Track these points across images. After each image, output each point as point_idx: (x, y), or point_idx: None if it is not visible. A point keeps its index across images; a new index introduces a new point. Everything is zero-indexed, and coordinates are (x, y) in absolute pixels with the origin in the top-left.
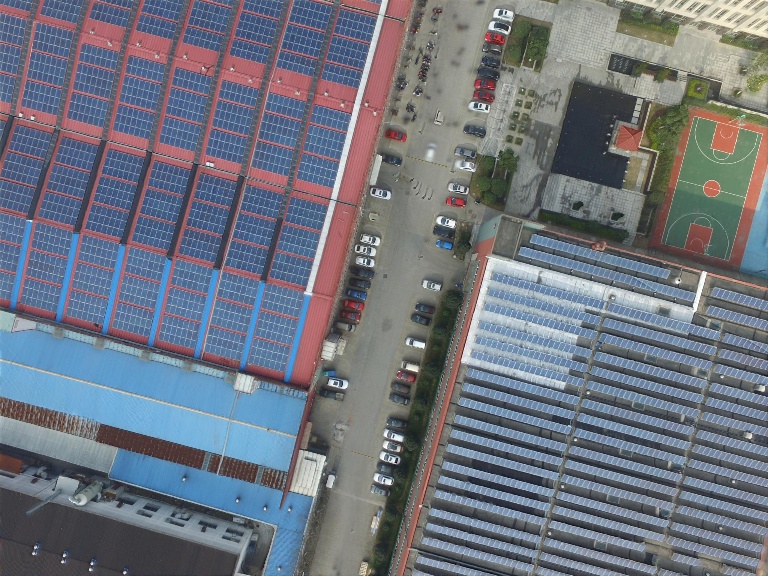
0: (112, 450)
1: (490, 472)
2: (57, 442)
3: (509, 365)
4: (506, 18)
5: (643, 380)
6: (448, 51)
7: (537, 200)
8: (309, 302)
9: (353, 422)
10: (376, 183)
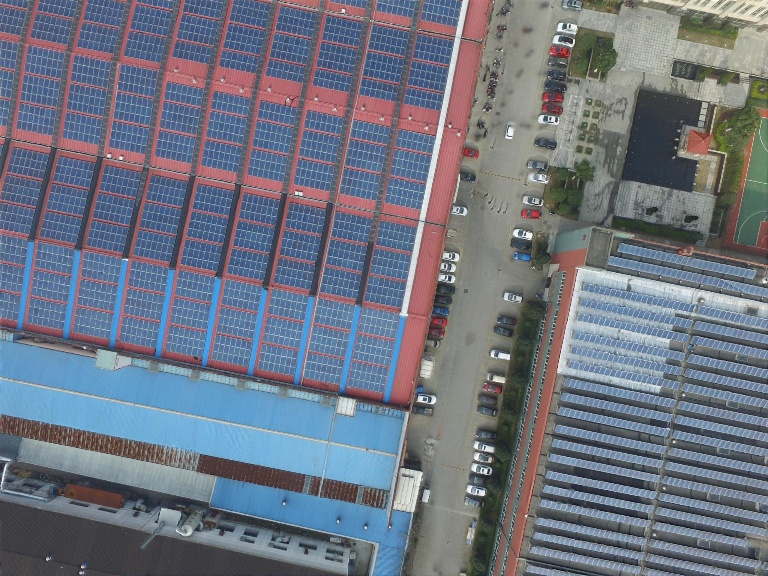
0: (209, 479)
1: (593, 478)
2: (155, 474)
3: (605, 373)
4: (570, 31)
5: (737, 379)
6: (514, 67)
7: (610, 207)
8: (405, 323)
9: (443, 436)
10: None
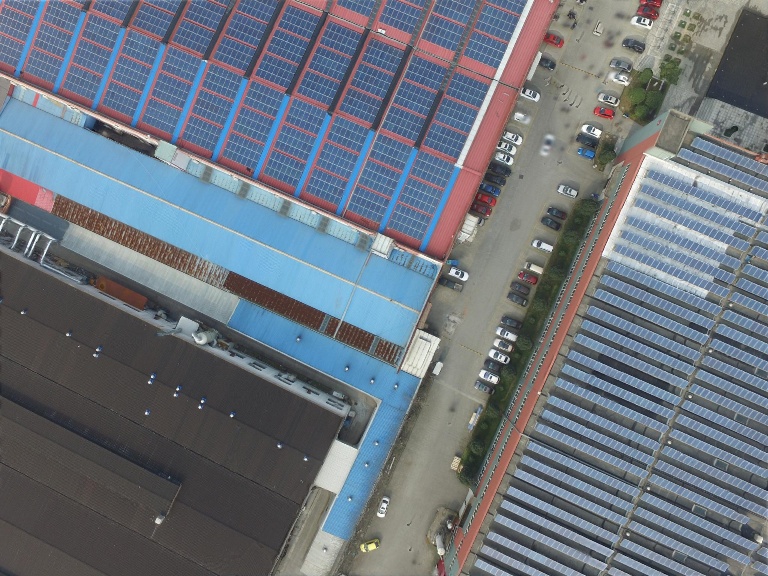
0: (232, 302)
1: (617, 369)
2: (182, 286)
3: (652, 264)
4: None
5: None
6: None
7: None
8: (458, 175)
9: (467, 316)
10: (527, 84)
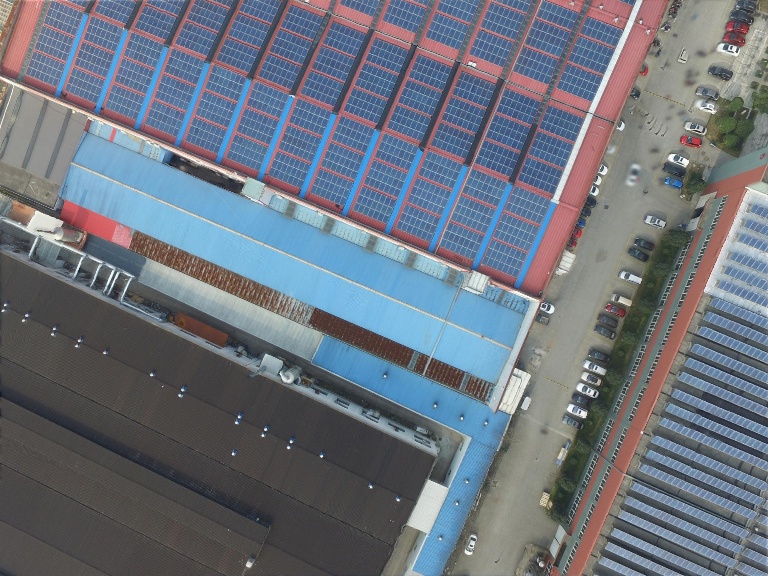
0: (315, 338)
1: (723, 408)
2: (263, 322)
3: (757, 301)
4: None
5: None
6: None
7: None
8: (554, 210)
9: (553, 349)
10: None
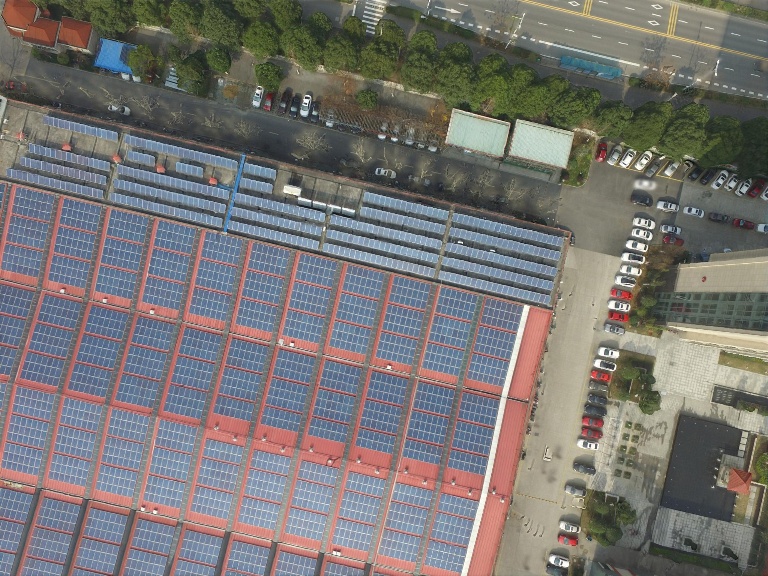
0: None
1: None
2: None
3: None
4: (612, 357)
5: None
6: (554, 387)
7: (647, 533)
8: None
9: None
10: None
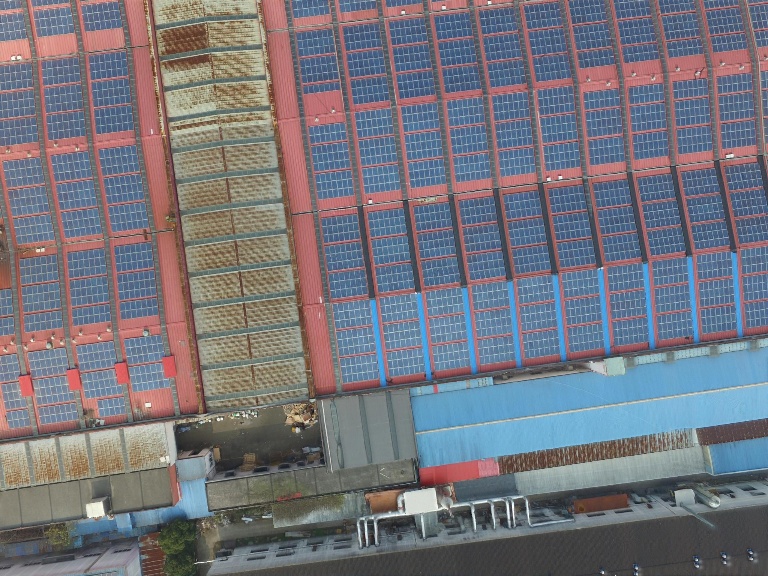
0: (696, 451)
1: None
2: (646, 465)
3: None
4: None
5: None
6: None
7: None
8: None
9: None
10: None
